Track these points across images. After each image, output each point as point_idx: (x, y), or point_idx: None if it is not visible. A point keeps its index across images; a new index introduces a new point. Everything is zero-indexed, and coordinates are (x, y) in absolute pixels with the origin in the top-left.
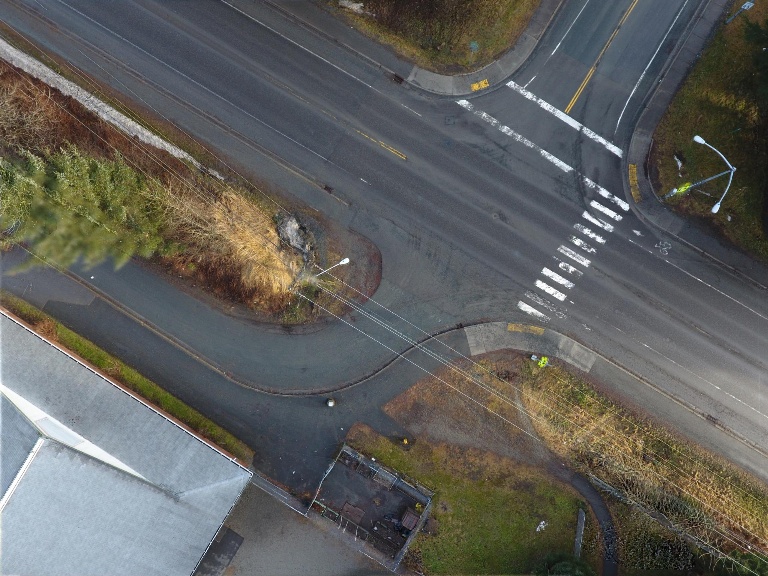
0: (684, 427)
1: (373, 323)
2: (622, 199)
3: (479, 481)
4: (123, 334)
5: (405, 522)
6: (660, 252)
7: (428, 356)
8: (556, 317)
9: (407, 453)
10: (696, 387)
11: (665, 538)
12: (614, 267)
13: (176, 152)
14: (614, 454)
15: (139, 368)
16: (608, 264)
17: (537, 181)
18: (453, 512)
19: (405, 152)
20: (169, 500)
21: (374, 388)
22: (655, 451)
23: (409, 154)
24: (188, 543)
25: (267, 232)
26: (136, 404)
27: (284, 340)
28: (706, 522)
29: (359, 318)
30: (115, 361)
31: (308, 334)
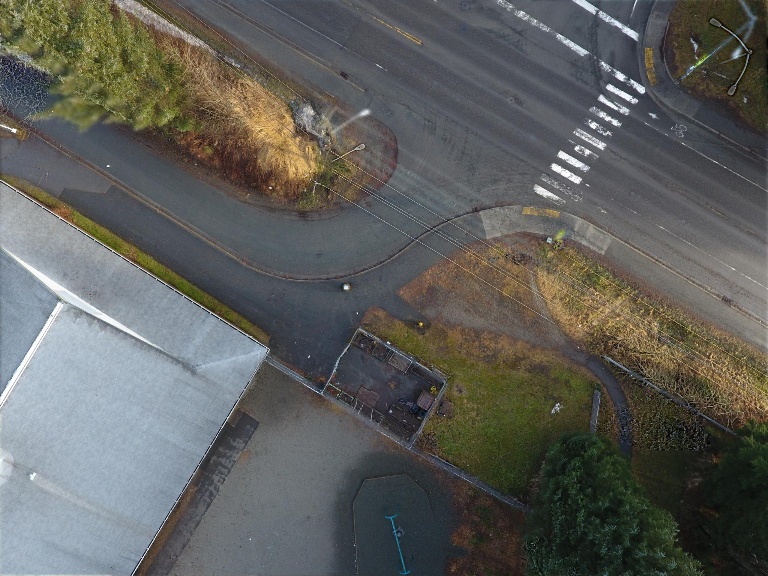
0: (699, 308)
1: (388, 208)
2: (638, 82)
3: (494, 364)
4: (139, 221)
5: (420, 402)
6: (676, 134)
7: (443, 240)
8: (572, 200)
9: (422, 337)
10: (712, 268)
11: (680, 420)
12: (630, 150)
13: (192, 40)
14: (629, 337)
15: (155, 255)
16: (624, 147)
17: (553, 65)
18: (468, 394)
19: (421, 37)
20: (186, 372)
21: (389, 272)
22: (670, 334)
23: (425, 39)
24: (205, 417)
25: (283, 117)
26: (153, 281)
27: (299, 226)
28: (721, 402)
29: (374, 203)
30: (131, 248)
31: (323, 220)
